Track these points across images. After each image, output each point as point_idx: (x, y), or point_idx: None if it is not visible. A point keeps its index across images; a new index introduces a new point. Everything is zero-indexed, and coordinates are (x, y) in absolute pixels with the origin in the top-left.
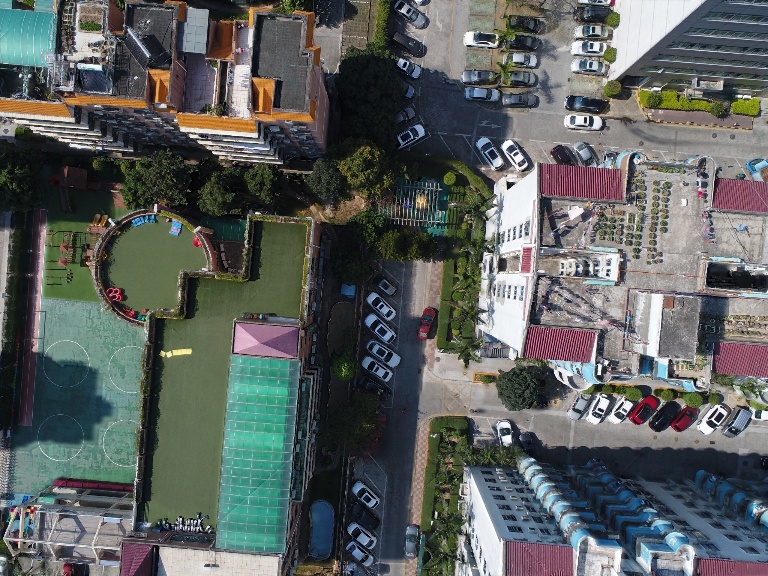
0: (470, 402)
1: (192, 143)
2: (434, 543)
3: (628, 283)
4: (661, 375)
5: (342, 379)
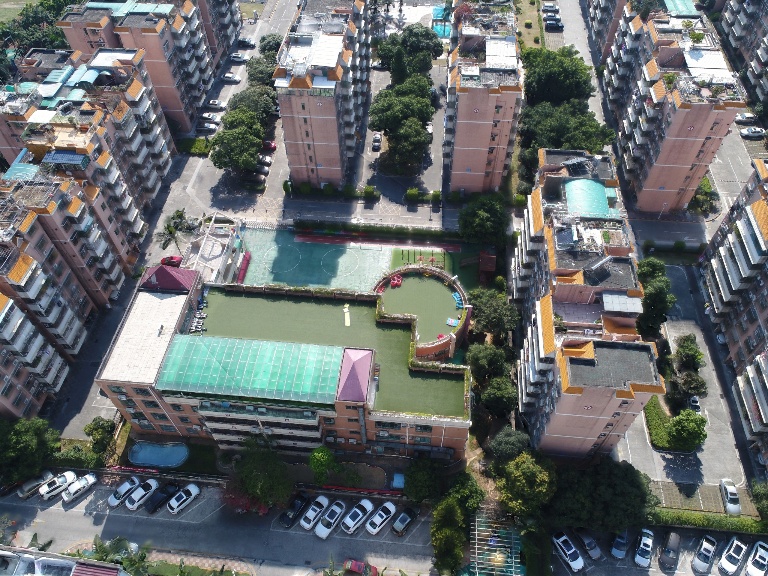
0: None
1: None
2: (121, 546)
3: None
4: None
5: None
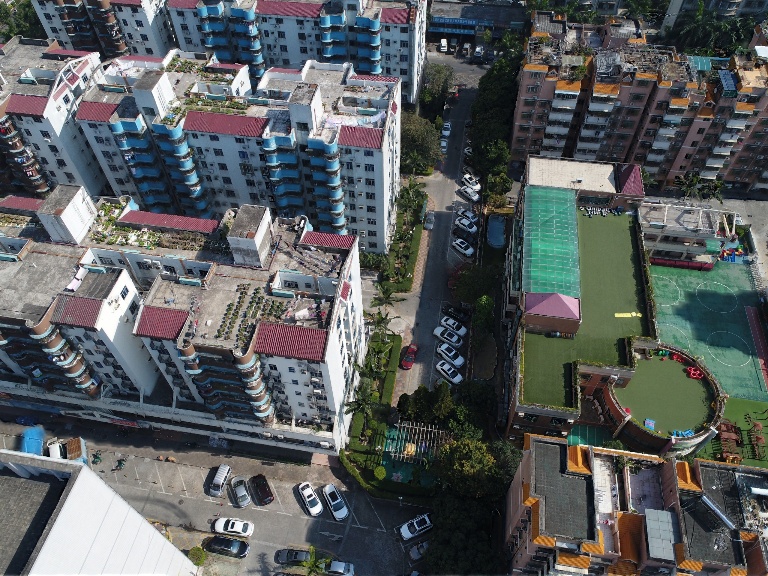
0: None
1: None
2: (418, 195)
3: (268, 274)
4: None
5: None
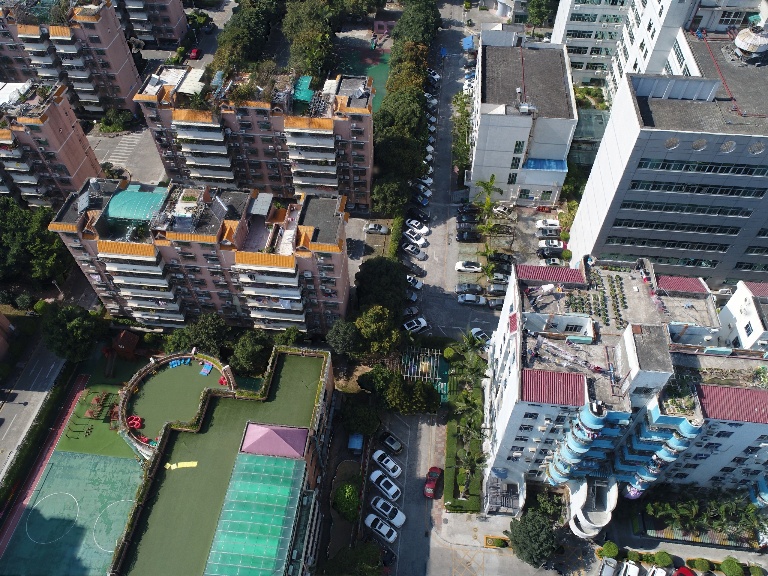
0: (483, 571)
1: (234, 315)
2: None
3: (605, 343)
4: (655, 416)
5: (345, 508)
